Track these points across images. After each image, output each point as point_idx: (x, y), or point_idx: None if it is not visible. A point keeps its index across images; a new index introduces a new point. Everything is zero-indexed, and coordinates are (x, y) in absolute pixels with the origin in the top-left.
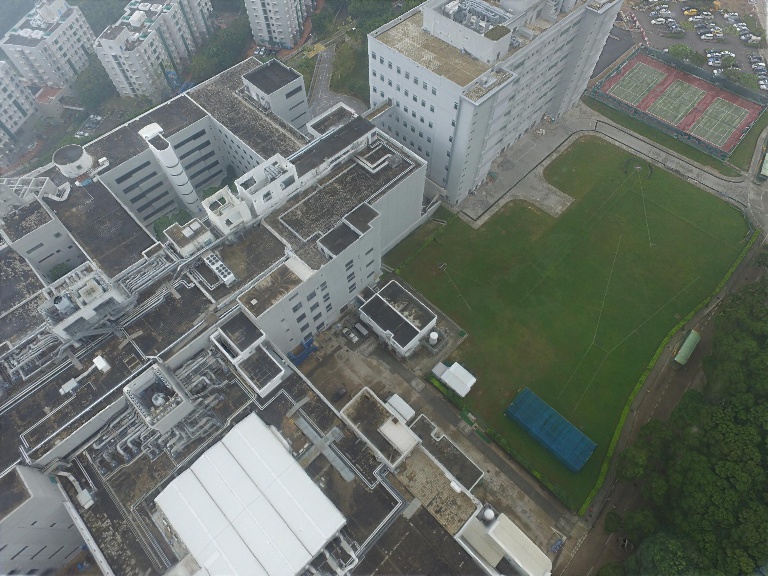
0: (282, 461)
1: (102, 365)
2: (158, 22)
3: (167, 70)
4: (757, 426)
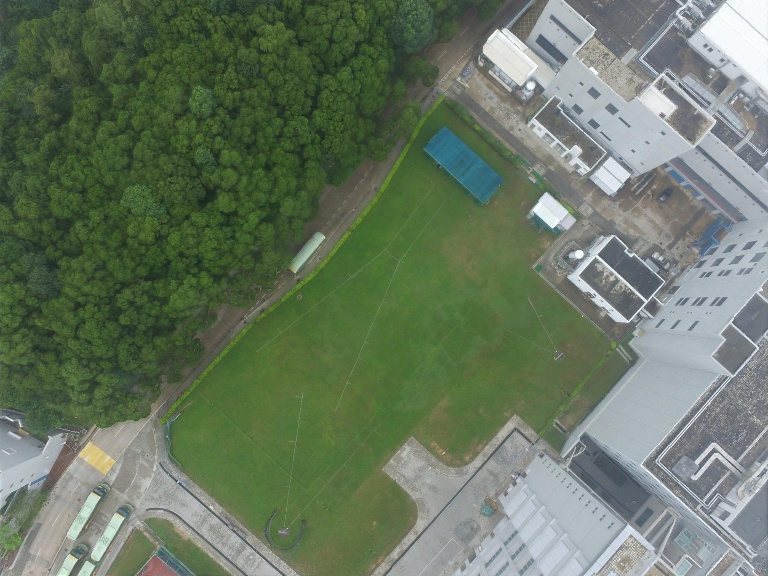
0: (766, 75)
1: None
2: None
3: None
4: (311, 125)
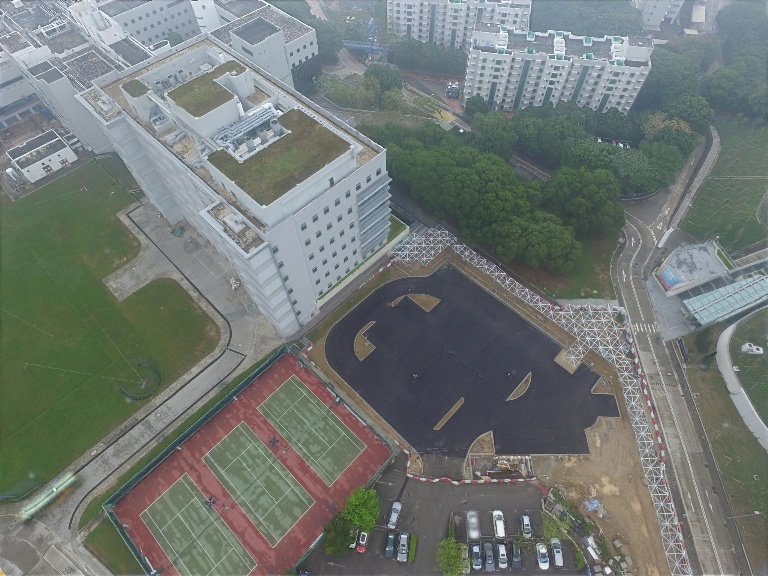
0: None
1: (14, 1)
2: (438, 2)
3: (414, 35)
4: None
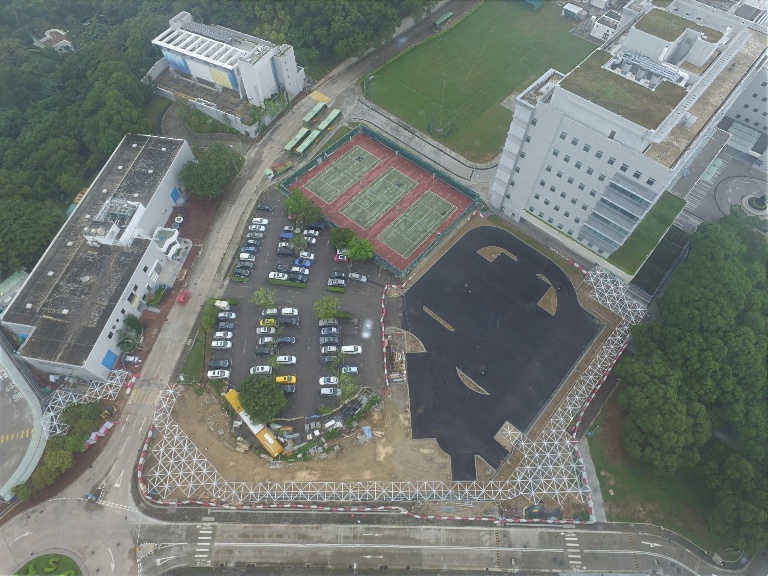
0: None
1: None
2: None
3: None
4: None
